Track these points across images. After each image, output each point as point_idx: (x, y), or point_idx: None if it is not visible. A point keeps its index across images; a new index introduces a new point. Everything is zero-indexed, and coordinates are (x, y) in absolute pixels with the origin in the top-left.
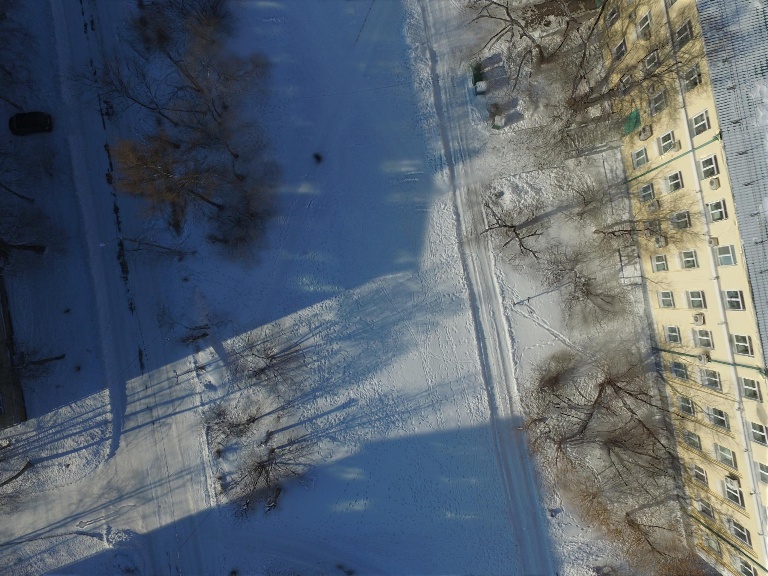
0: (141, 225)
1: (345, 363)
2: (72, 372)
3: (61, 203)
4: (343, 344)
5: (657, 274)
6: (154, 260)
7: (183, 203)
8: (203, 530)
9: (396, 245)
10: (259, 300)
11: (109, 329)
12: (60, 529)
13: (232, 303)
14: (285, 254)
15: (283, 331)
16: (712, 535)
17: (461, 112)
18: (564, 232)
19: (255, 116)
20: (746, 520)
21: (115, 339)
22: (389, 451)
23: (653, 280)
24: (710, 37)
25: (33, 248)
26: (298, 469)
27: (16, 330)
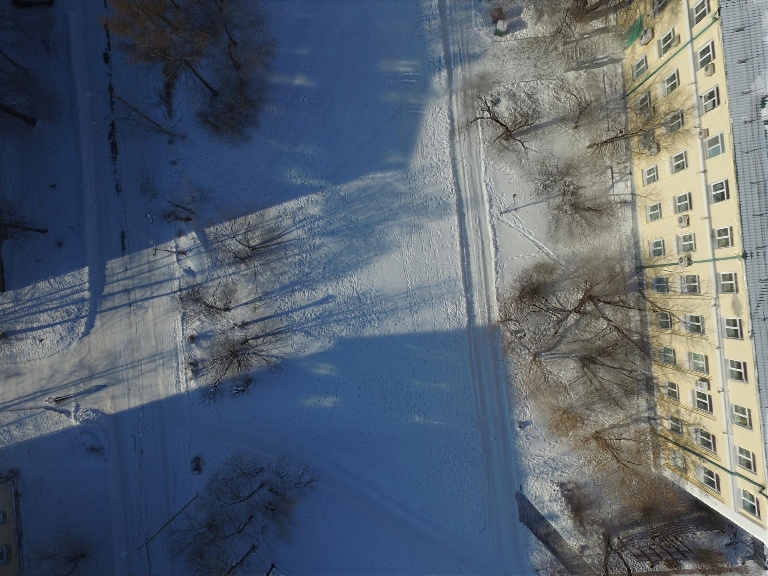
0: (134, 105)
1: (326, 259)
2: (53, 247)
3: (56, 77)
4: (326, 239)
5: (647, 187)
6: (142, 133)
7: (177, 85)
8: (171, 415)
9: (387, 145)
10: (245, 189)
11: (94, 208)
12: (29, 403)
13: (218, 190)
14: (275, 145)
15: (267, 222)
16: (679, 450)
17: (464, 16)
18: (558, 144)
19: (257, 4)
20: (712, 423)
21: (99, 218)
22: (363, 350)
23: (643, 195)
24: None
25: (24, 117)
26: (270, 361)
27: (1, 200)
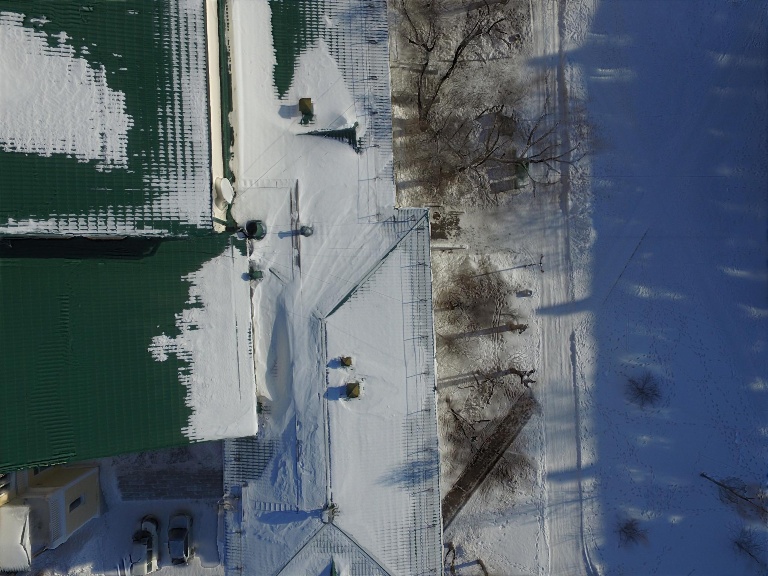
0: None
1: None
2: None
3: None
4: None
5: None
6: None
7: None
8: None
9: None
10: None
11: None
12: None
13: None
14: (757, 6)
15: None
16: None
17: None
18: None
19: None
20: None
21: None
22: None
23: None
24: (381, 1)
25: None
26: None
27: None
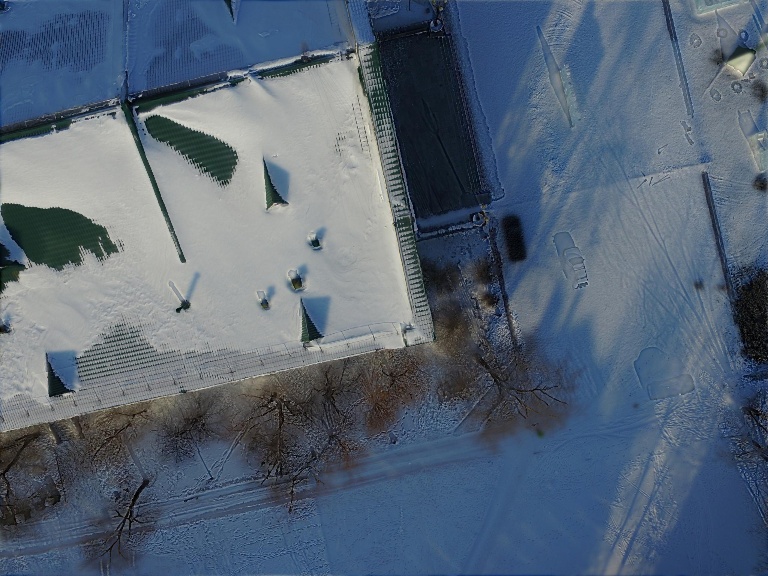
0: None
1: None
2: None
3: None
4: None
5: None
6: None
7: None
8: None
9: None
10: None
11: None
12: None
13: None
14: None
15: None
16: None
17: (47, 529)
18: (146, 438)
19: None
20: None
21: None
22: None
23: None
24: None
25: None
26: None
27: None
